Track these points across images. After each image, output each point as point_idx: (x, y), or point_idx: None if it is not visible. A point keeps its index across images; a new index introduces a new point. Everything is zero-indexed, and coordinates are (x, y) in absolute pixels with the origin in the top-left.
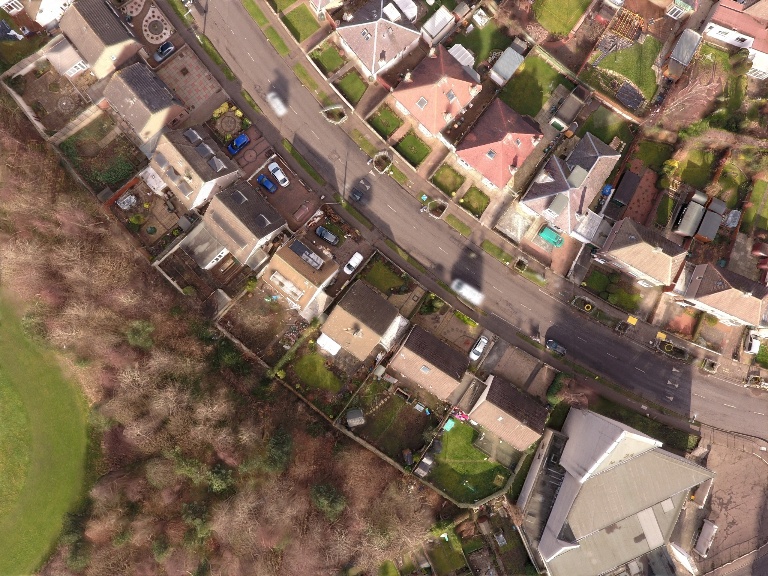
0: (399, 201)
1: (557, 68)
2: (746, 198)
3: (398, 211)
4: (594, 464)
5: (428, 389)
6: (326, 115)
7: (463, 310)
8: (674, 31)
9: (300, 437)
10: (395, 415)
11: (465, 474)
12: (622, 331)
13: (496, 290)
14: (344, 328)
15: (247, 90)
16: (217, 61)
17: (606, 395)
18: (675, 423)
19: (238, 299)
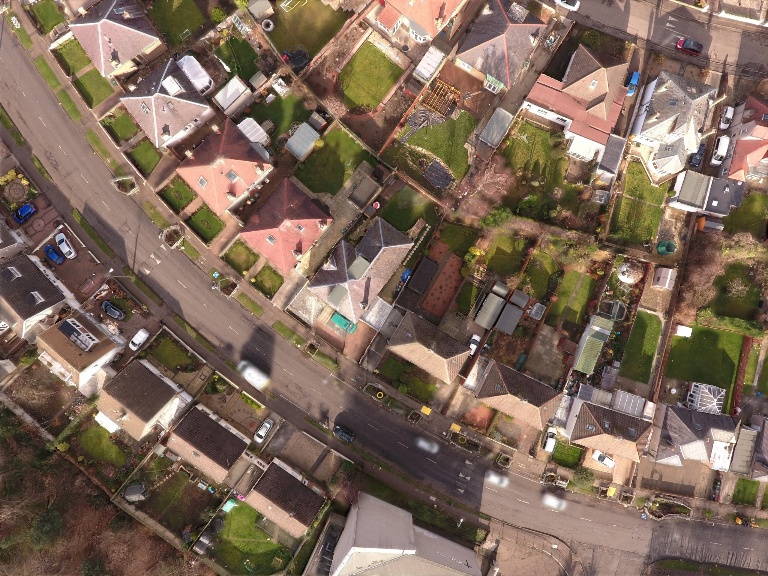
0: (190, 277)
1: (360, 144)
2: (556, 289)
3: (189, 287)
4: (335, 570)
5: (204, 472)
6: (117, 185)
7: (250, 391)
8: (493, 106)
9: (73, 512)
10: (179, 491)
11: (248, 552)
12: (414, 421)
13: (286, 373)
14: (114, 410)
15: (37, 156)
16: (7, 125)
17: (393, 484)
18: (464, 516)
19: (23, 370)
